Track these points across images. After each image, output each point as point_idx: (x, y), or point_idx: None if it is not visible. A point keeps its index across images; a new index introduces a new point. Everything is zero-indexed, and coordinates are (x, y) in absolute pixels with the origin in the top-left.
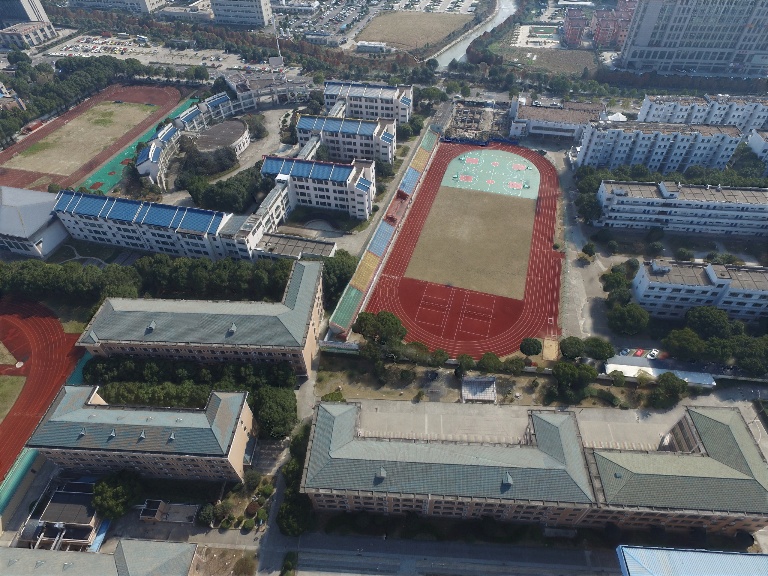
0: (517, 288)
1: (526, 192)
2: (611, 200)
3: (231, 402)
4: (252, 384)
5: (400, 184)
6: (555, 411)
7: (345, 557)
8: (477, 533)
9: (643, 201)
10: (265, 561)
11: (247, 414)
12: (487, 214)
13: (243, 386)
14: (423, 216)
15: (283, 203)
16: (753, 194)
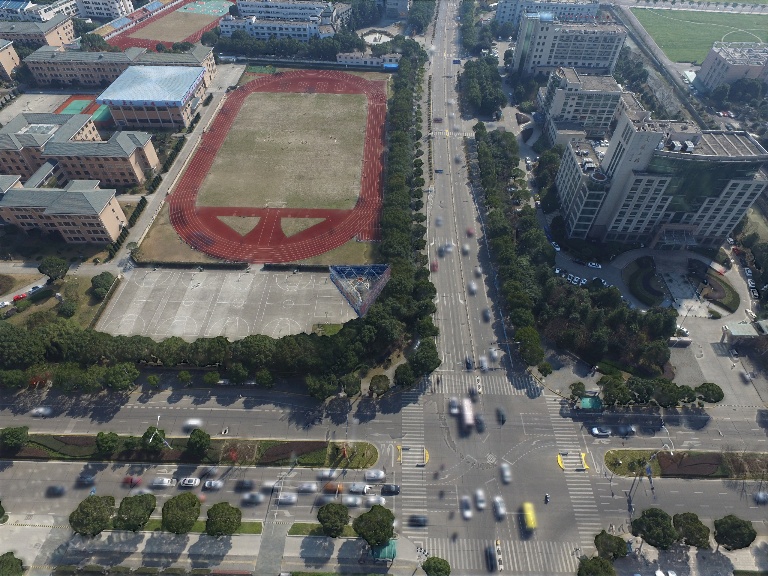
0: (179, 40)
1: (219, 13)
2: (240, 5)
3: (2, 41)
4: (21, 49)
5: (146, 6)
6: (139, 47)
7: (44, 92)
8: (99, 87)
9: (255, 5)
10: (11, 93)
11: (14, 54)
12: (189, 20)
13: (16, 48)
14: (154, 20)
15: (73, 8)
16: (309, 2)
